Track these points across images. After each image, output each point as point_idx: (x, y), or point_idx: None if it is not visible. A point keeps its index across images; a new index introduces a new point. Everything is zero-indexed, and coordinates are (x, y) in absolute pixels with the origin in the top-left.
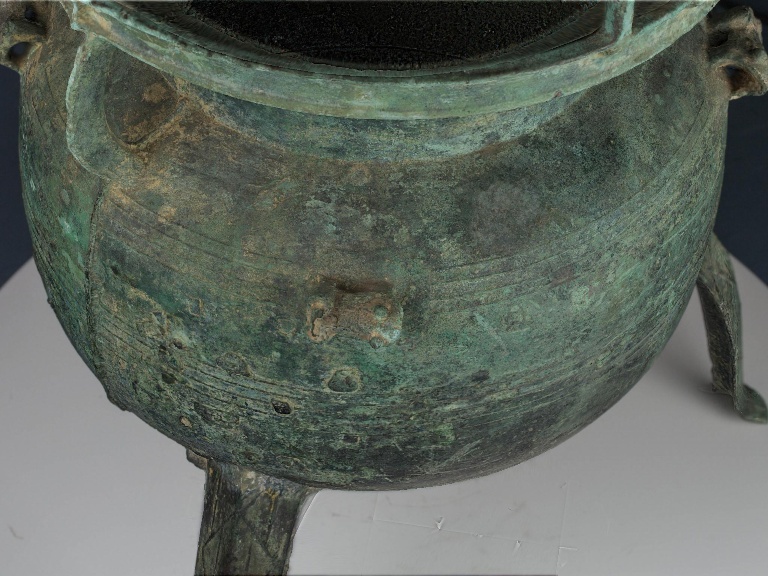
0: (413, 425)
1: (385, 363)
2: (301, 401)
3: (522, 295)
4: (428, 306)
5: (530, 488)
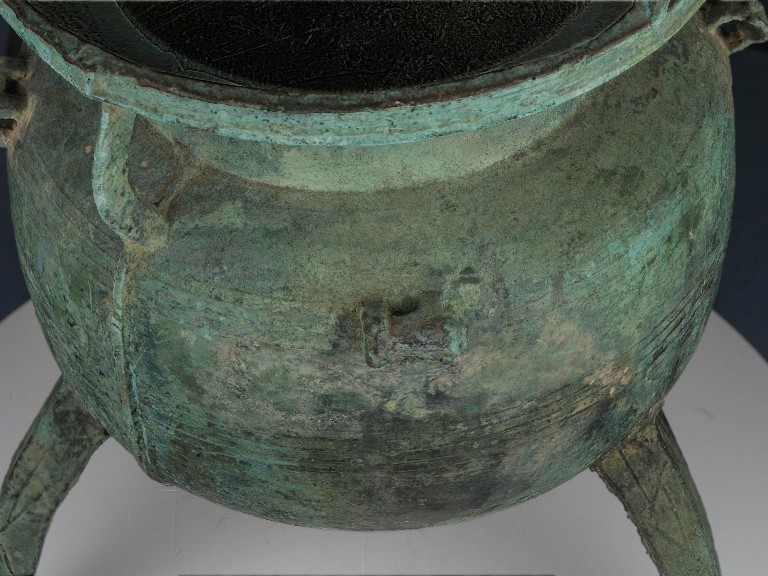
0: None
1: None
2: None
3: None
4: None
5: (211, 544)
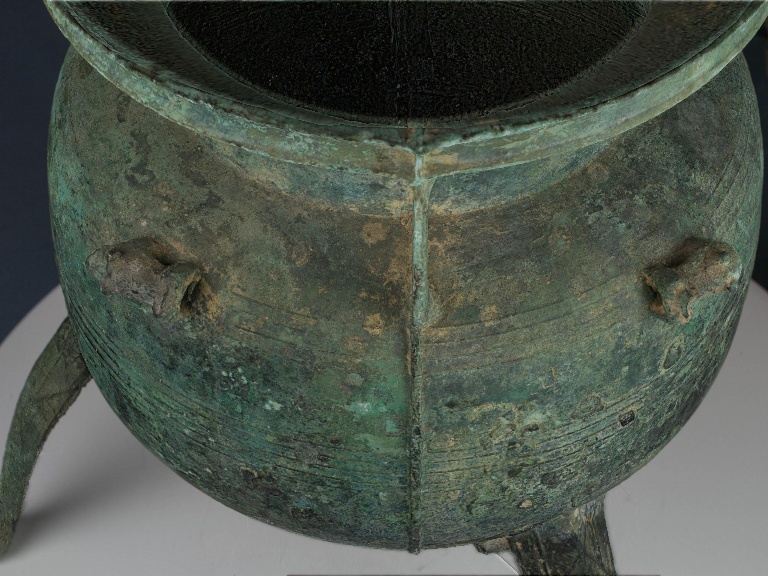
0: (709, 358)
1: (698, 313)
2: (642, 400)
3: (750, 183)
4: (716, 237)
5: None
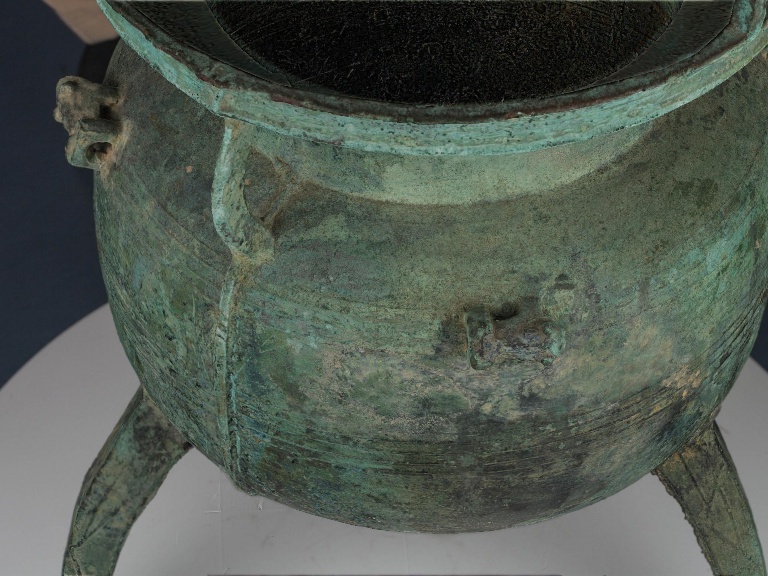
0: (332, 6)
1: None
2: None
3: None
4: None
5: (259, 562)
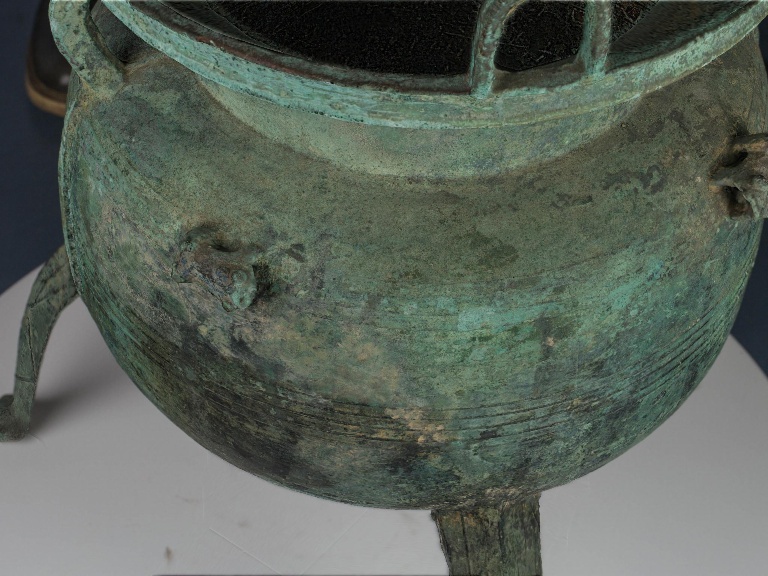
0: None
1: None
2: None
3: None
4: None
5: None
